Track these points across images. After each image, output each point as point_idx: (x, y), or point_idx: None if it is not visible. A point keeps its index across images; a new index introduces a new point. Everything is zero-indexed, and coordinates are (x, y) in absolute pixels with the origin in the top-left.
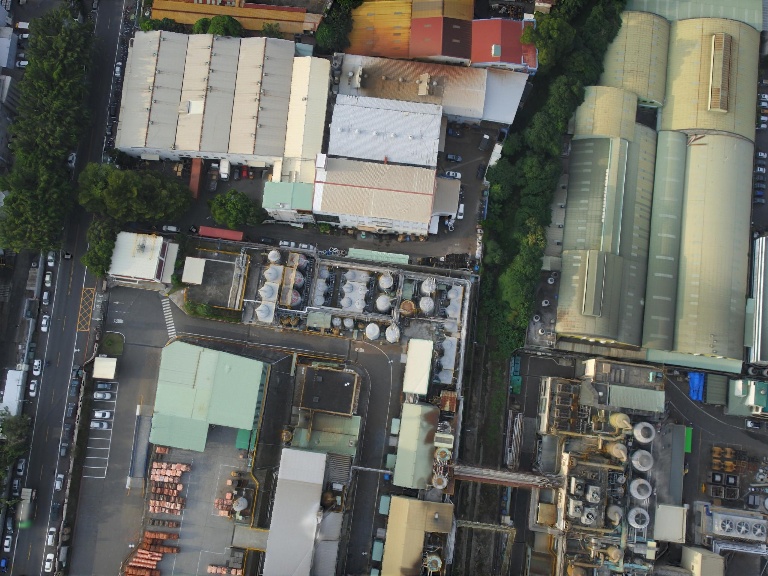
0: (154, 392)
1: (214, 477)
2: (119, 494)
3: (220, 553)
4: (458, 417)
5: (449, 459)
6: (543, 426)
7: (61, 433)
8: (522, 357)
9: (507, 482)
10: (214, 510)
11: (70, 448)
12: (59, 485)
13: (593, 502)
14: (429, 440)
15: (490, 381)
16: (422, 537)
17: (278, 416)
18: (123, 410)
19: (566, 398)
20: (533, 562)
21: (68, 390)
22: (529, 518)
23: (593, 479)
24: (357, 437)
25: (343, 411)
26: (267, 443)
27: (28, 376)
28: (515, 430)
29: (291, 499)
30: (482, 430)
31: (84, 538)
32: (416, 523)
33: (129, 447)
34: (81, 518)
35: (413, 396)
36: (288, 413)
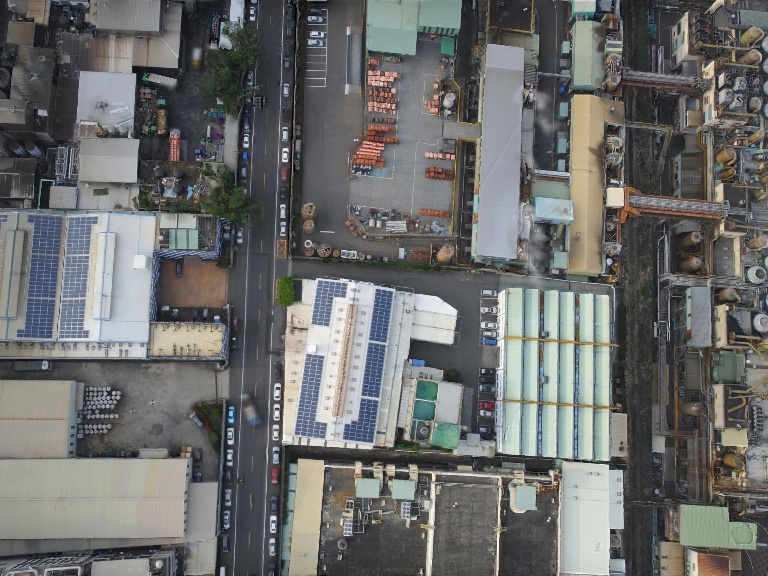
0: (360, 16)
1: (421, 84)
2: (340, 99)
3: (433, 144)
4: (620, 35)
5: (619, 62)
6: (682, 56)
7: (281, 51)
8: (654, 11)
9: (665, 85)
10: (424, 110)
11: (292, 63)
12: (287, 91)
13: (741, 89)
14: (601, 49)
15: (635, 21)
16: (602, 125)
17: (467, 40)
18: (335, 31)
19: (704, 23)
20: (684, 162)
21: (283, 16)
22: (679, 124)
23: (738, 73)
24: (538, 52)
25: (525, 30)
26: (462, 58)
27: (246, 5)
28: (659, 60)
29: (499, 83)
30: (632, 60)
31: (313, 135)
32: (597, 114)
33: (344, 61)
34: (308, 120)
35: (582, 17)
36: (474, 39)
